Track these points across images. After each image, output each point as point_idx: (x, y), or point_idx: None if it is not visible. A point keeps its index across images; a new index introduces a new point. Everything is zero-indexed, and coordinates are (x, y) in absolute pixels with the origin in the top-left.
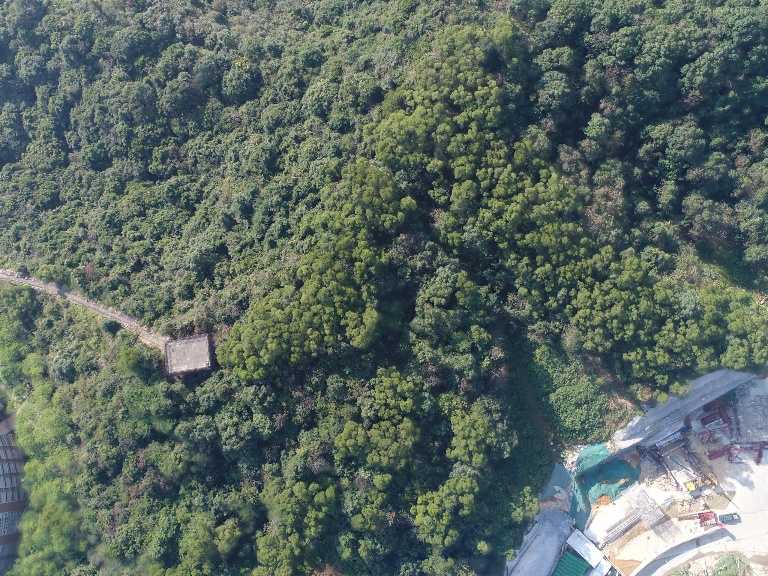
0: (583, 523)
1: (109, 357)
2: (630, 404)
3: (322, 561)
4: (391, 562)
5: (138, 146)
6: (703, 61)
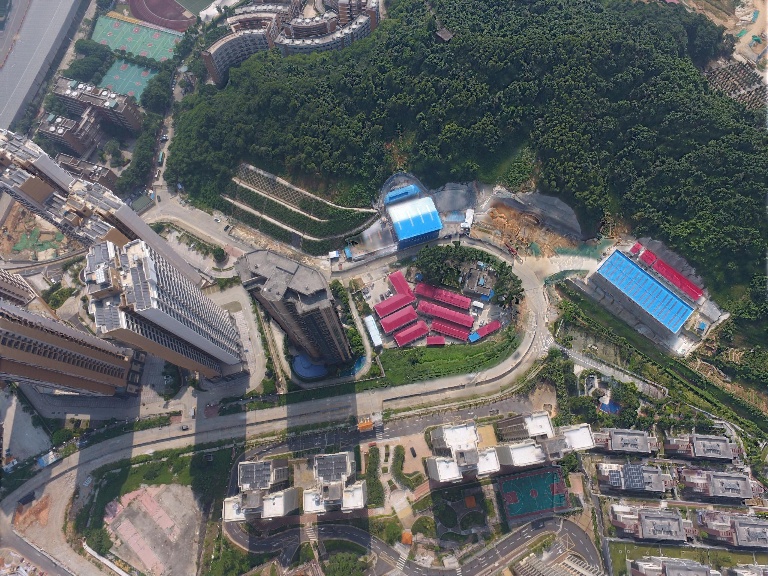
0: (477, 211)
1: (424, 25)
2: (534, 186)
3: (405, 129)
4: (422, 141)
5: (493, 1)
6: (680, 113)
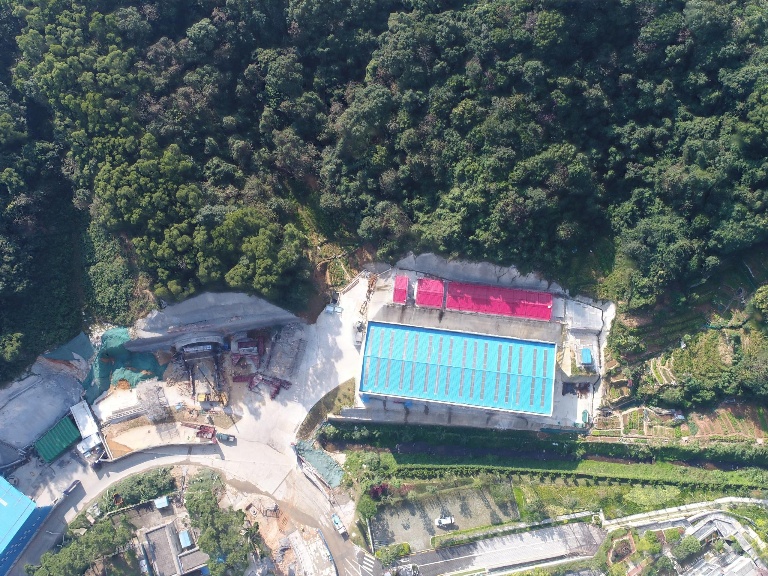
0: (93, 397)
1: None
2: (152, 296)
3: None
4: None
5: None
6: None
